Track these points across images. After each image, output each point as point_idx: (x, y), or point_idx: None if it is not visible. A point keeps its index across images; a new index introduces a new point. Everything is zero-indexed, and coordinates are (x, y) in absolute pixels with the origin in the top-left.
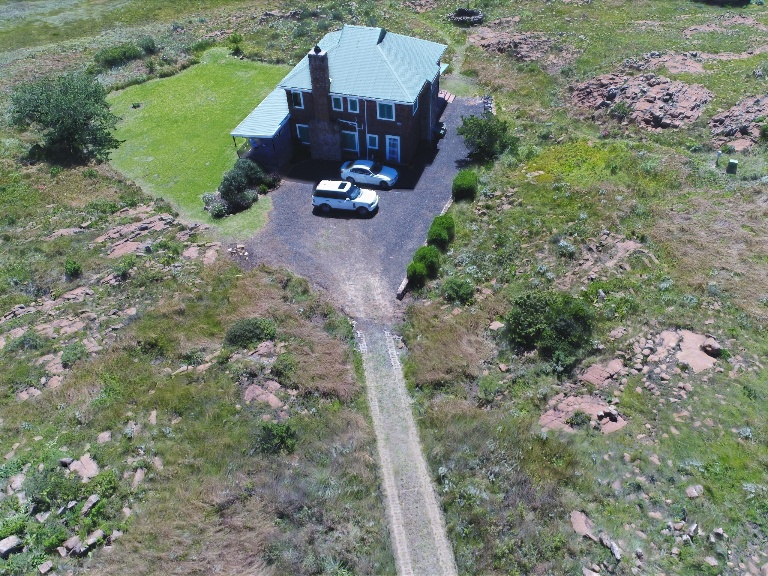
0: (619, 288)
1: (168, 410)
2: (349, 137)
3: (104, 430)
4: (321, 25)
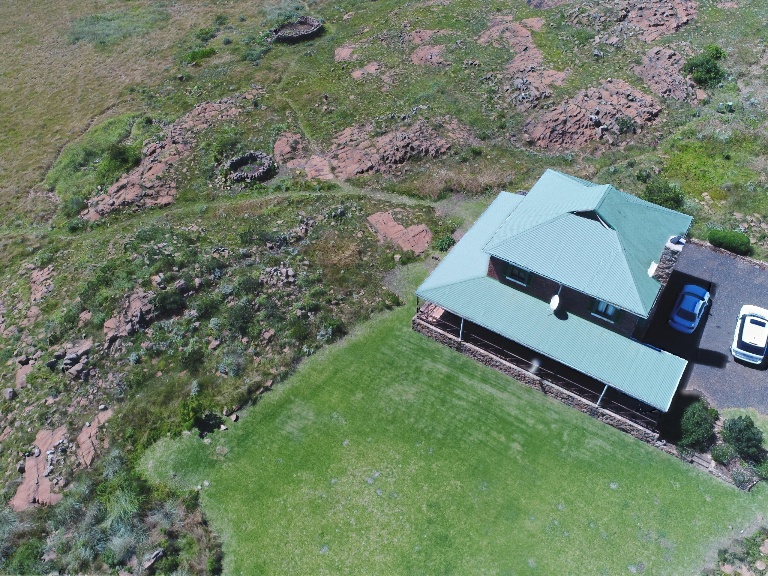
0: None
1: None
2: None
3: None
4: (252, 285)
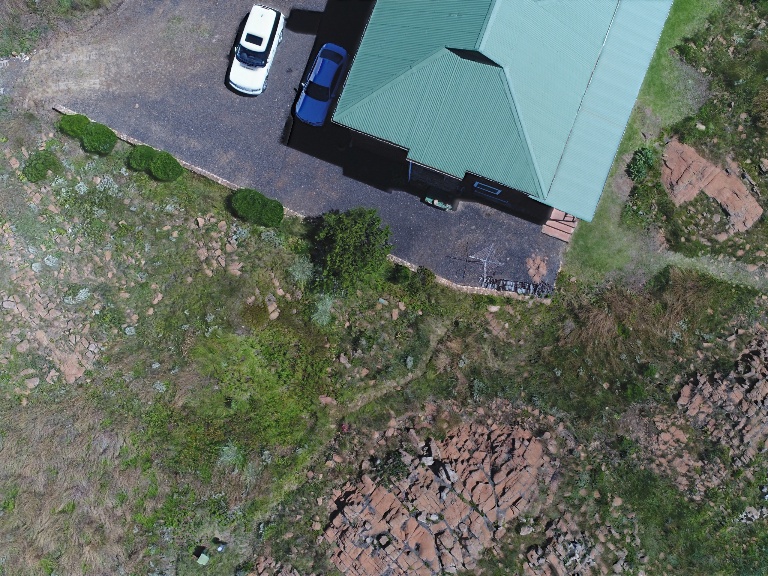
0: None
1: None
2: None
3: None
4: None
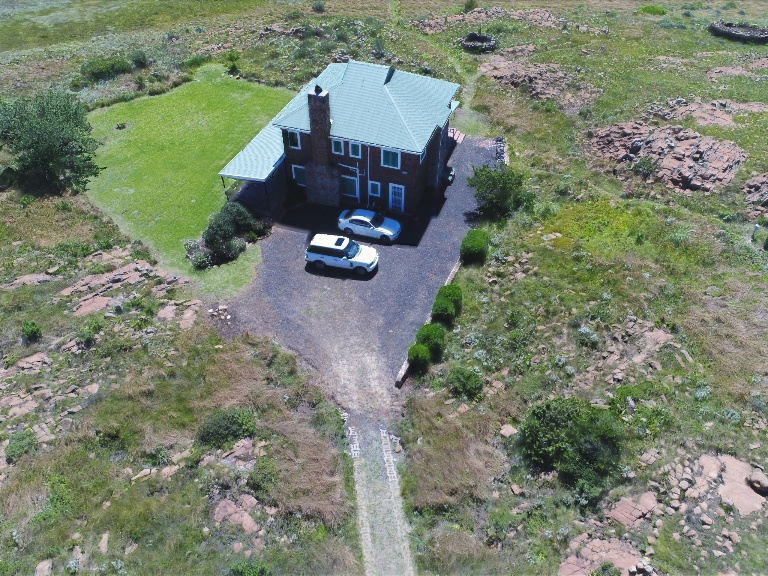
0: (649, 394)
1: (122, 534)
2: (349, 182)
3: (44, 558)
4: (324, 47)
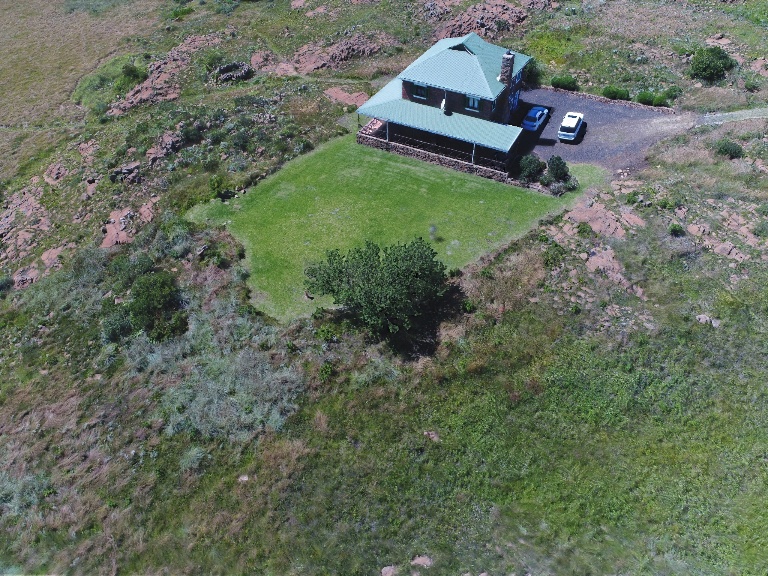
0: None
1: None
2: None
3: None
4: (247, 121)
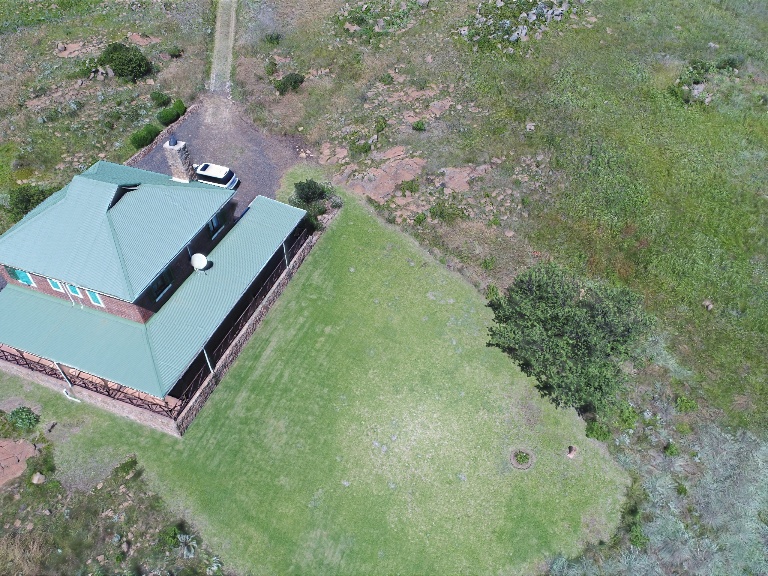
0: None
1: None
2: None
3: None
4: None
